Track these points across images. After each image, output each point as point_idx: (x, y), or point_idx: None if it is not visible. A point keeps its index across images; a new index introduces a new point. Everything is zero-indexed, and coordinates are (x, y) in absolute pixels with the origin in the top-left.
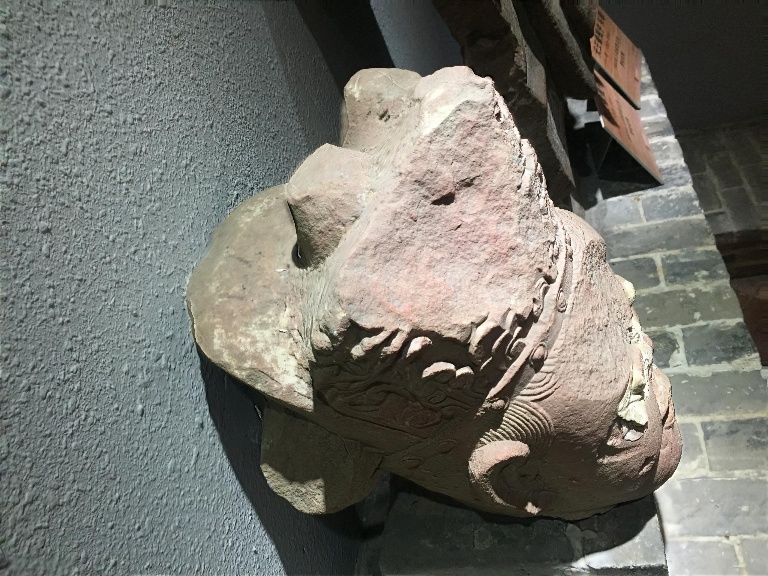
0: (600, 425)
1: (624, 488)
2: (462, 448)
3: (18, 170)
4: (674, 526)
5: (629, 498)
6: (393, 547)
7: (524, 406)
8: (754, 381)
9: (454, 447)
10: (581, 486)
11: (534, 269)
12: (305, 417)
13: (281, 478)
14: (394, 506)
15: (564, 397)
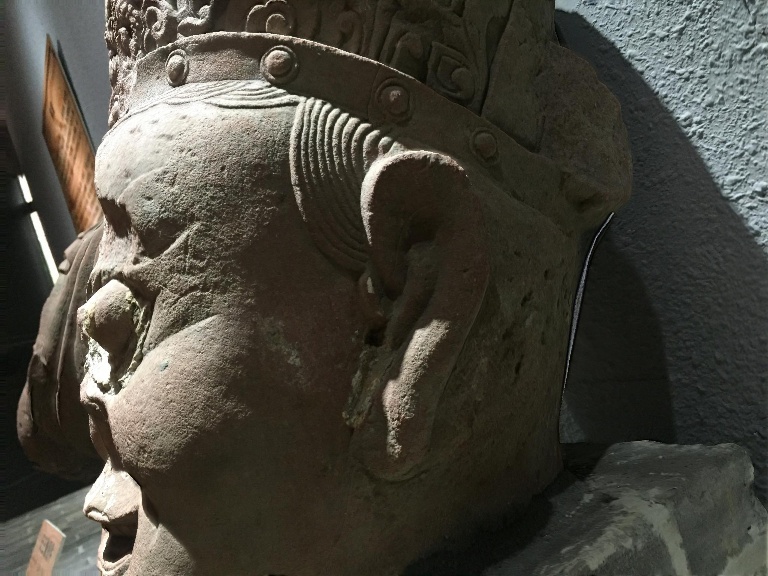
0: None
1: None
2: None
3: None
4: None
5: None
6: None
7: None
8: None
9: None
10: None
11: None
12: None
13: None
14: None
15: None
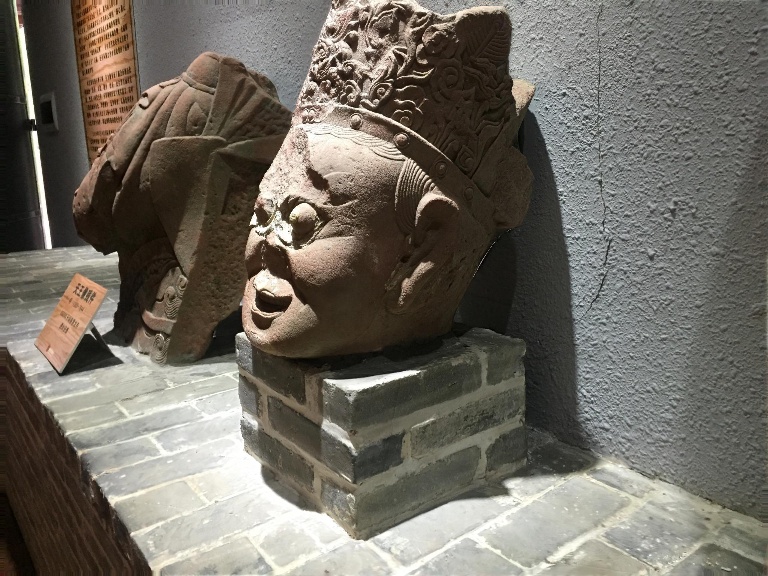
0: None
1: None
2: None
3: None
4: (262, 491)
5: None
6: None
7: None
8: None
9: None
10: None
11: None
12: None
13: None
14: None
15: None
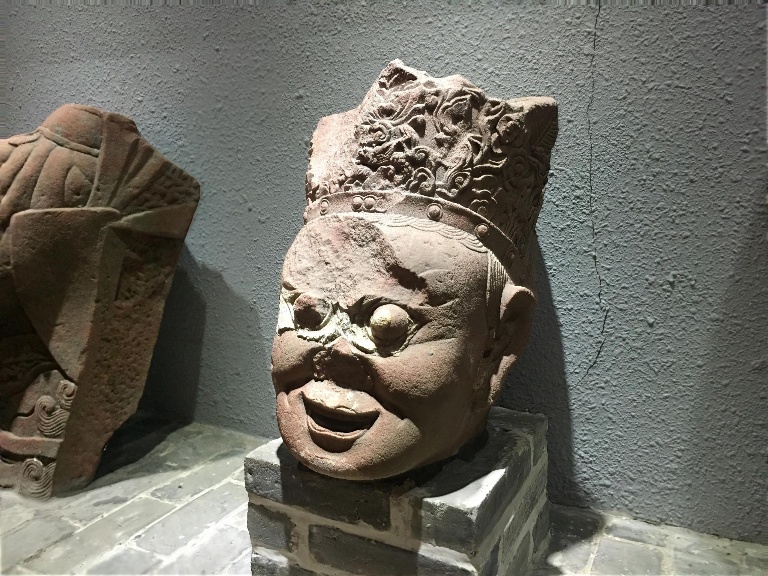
0: None
1: None
2: None
3: (410, 50)
4: None
5: None
6: None
7: None
8: None
9: None
10: None
11: (329, 172)
12: None
13: None
14: None
15: None
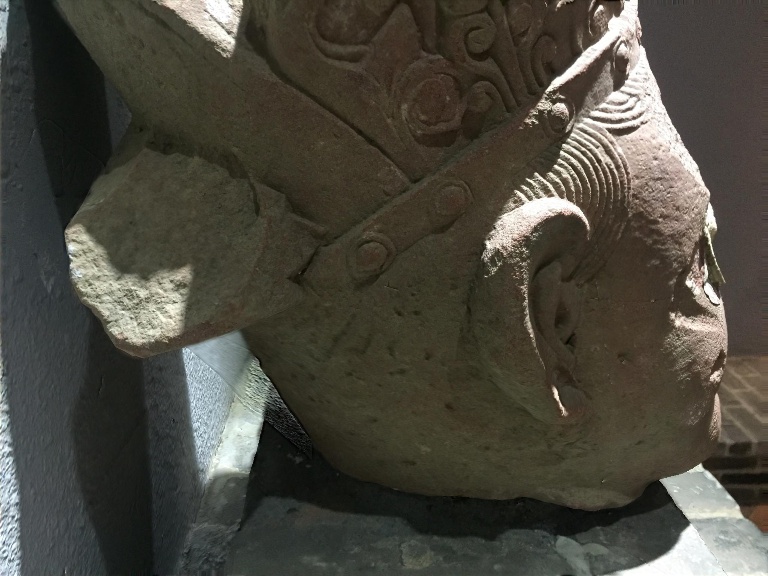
0: (688, 227)
1: (687, 404)
2: (478, 213)
3: None
4: None
5: (676, 452)
6: (248, 568)
7: (596, 134)
8: (700, 481)
9: (462, 214)
10: (632, 377)
11: None
12: (188, 146)
13: (103, 261)
14: (253, 517)
15: (653, 141)
